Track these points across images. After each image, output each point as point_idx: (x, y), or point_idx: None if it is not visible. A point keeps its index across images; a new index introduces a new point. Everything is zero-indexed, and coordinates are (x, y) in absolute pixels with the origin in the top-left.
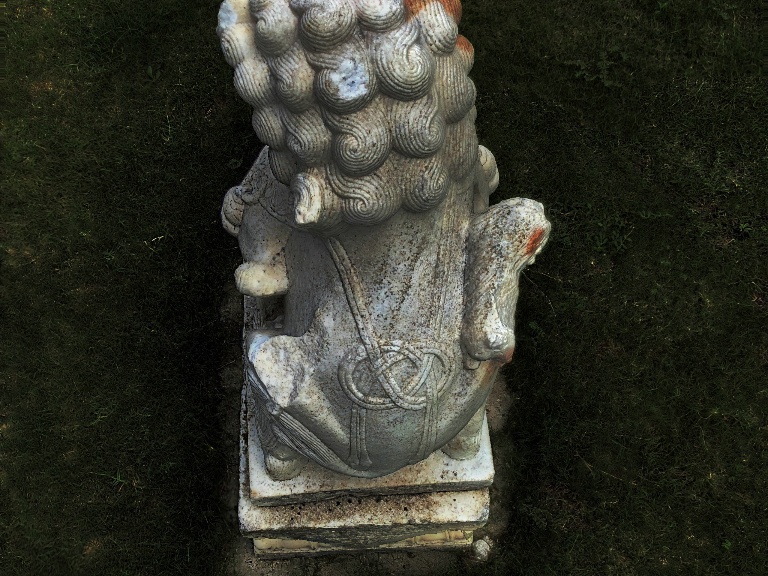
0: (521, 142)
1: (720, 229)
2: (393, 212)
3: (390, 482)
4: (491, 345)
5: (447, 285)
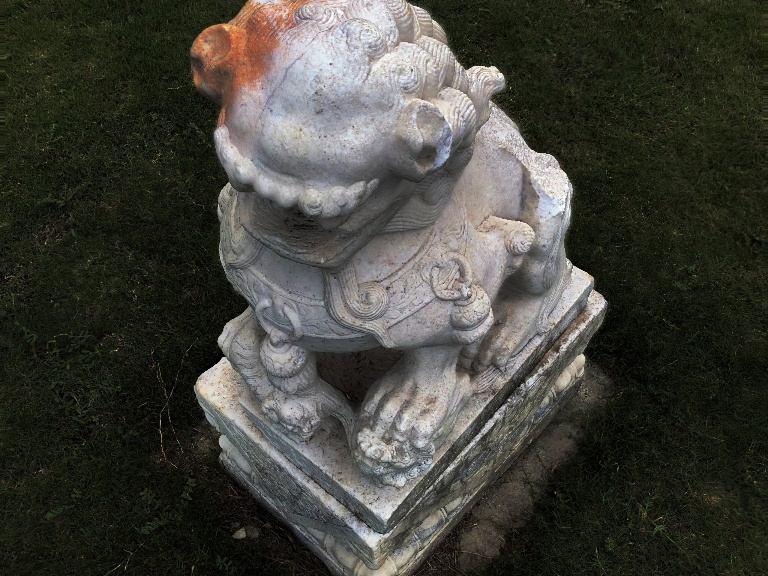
0: (5, 500)
1: (2, 289)
2: None
3: None
4: None
5: None
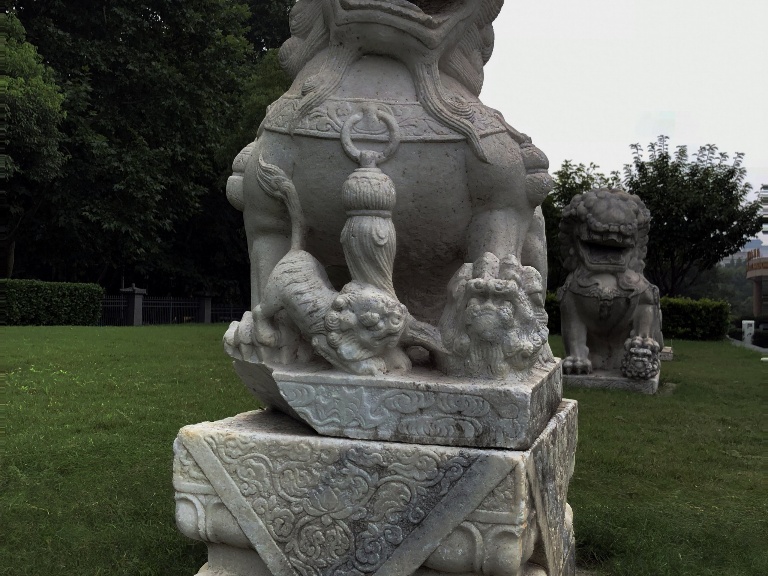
0: None
1: None
2: None
3: None
4: None
5: None
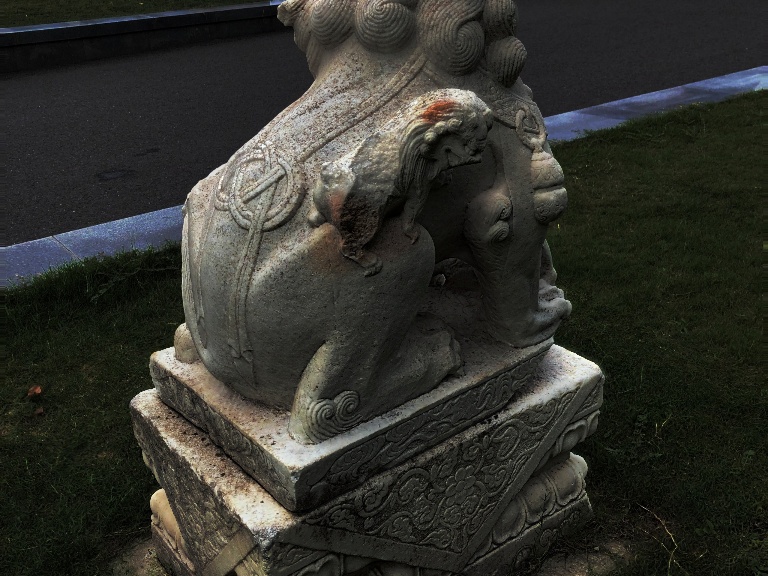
0: None
1: None
2: (340, 24)
3: (227, 411)
4: (322, 171)
5: (350, 130)
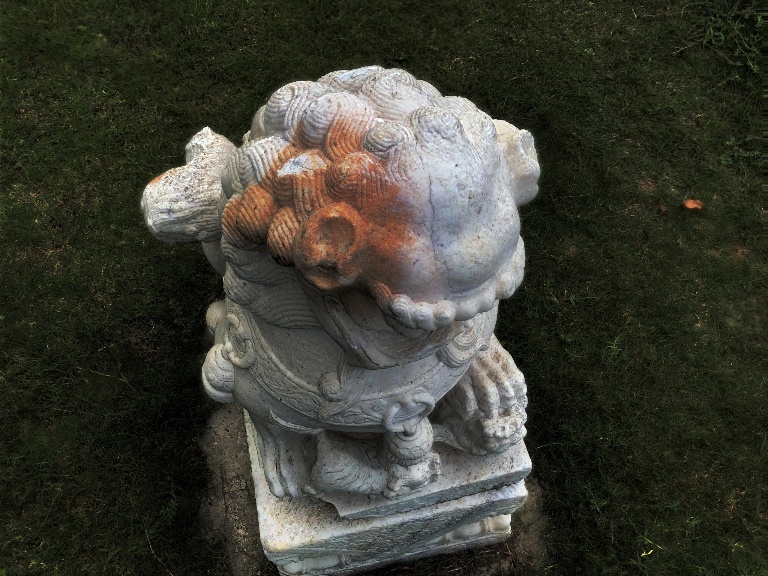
0: None
1: None
2: None
3: None
4: None
5: None
